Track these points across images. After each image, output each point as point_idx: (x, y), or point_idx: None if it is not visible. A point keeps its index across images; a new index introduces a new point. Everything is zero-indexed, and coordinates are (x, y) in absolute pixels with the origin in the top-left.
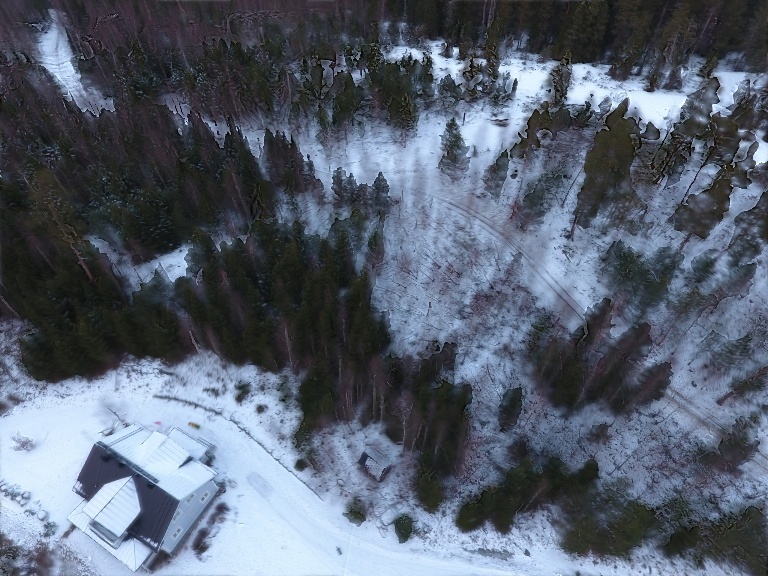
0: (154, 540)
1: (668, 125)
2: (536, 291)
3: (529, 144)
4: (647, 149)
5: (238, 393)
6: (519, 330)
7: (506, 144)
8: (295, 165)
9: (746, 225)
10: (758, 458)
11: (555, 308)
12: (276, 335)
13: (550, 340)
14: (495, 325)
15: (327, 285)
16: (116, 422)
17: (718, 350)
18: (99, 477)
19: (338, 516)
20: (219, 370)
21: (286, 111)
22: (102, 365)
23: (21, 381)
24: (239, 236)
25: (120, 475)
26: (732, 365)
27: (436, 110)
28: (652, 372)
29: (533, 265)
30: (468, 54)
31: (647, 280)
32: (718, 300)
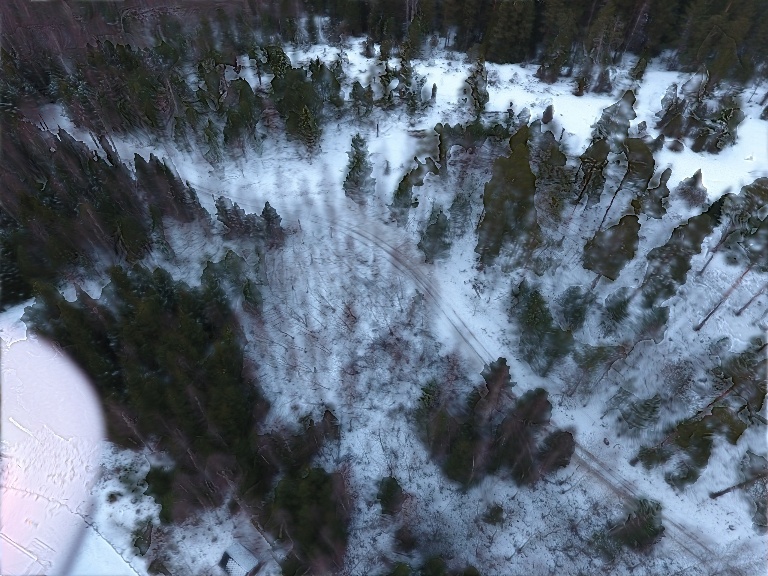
0: None
1: (593, 135)
2: (440, 336)
3: (426, 171)
4: (571, 162)
5: (89, 477)
6: (418, 385)
7: (421, 159)
8: (174, 193)
9: (658, 263)
10: (671, 529)
11: (460, 356)
12: None
13: (452, 395)
14: (391, 380)
15: (183, 351)
16: None
17: (627, 409)
18: None
19: None
20: (69, 449)
21: (173, 126)
22: None
23: None
24: (107, 280)
25: None
26: (642, 427)
27: (350, 119)
28: (553, 441)
29: (439, 304)
30: (390, 54)
31: (551, 330)
32: (634, 343)
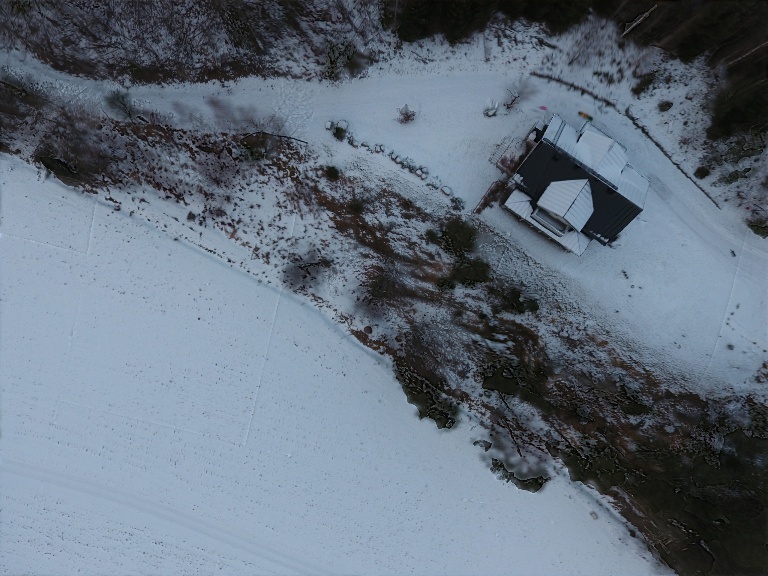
0: (605, 236)
1: None
2: None
3: None
4: None
5: (635, 82)
6: None
7: None
8: None
9: None
10: None
11: None
12: (744, 19)
13: None
14: None
15: None
16: (495, 101)
17: None
18: (545, 174)
19: (733, 224)
20: (614, 49)
21: None
22: (469, 25)
23: (368, 34)
24: None
25: (572, 176)
26: None
27: None
28: None
29: None
30: None
31: None
32: None
